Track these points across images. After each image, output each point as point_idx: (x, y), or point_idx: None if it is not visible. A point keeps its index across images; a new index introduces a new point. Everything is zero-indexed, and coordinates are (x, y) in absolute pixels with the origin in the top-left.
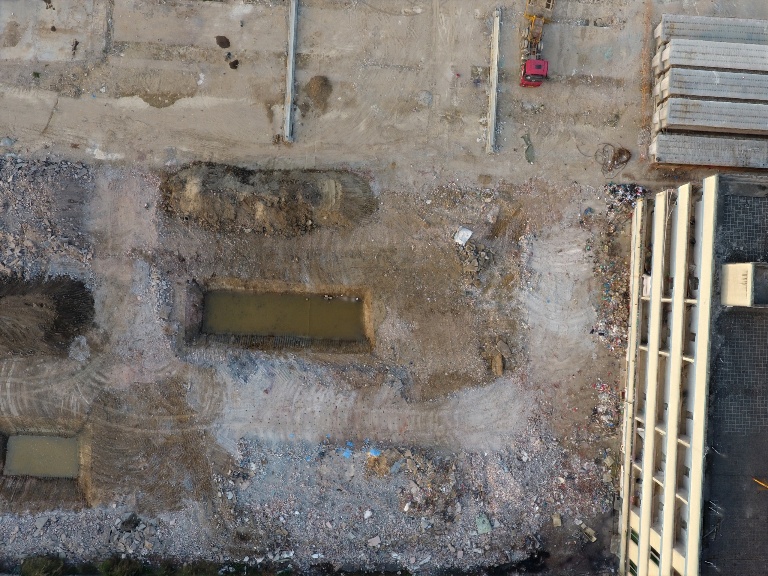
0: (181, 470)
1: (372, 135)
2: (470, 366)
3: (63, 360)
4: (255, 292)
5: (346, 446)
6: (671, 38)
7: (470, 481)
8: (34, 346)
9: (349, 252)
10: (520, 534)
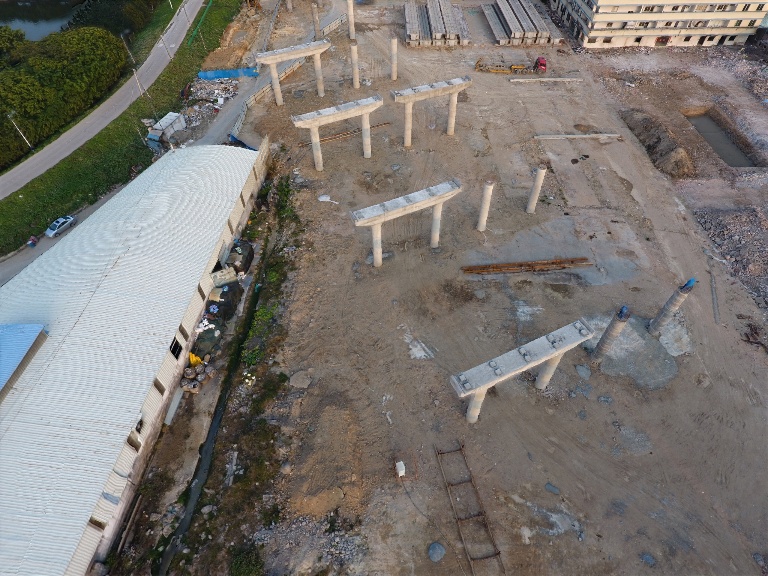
0: None
1: None
2: None
3: None
4: None
5: None
6: None
7: None
8: None
9: None
10: (761, 64)
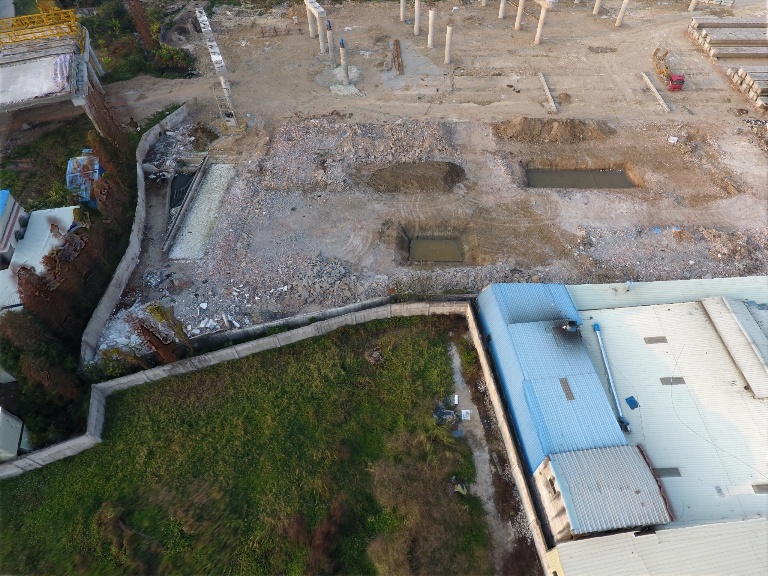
0: (542, 244)
1: (600, 109)
2: (714, 191)
3: (450, 194)
4: (556, 170)
5: (654, 228)
6: (738, 70)
7: (757, 241)
8: (435, 184)
9: (609, 148)
10: None
